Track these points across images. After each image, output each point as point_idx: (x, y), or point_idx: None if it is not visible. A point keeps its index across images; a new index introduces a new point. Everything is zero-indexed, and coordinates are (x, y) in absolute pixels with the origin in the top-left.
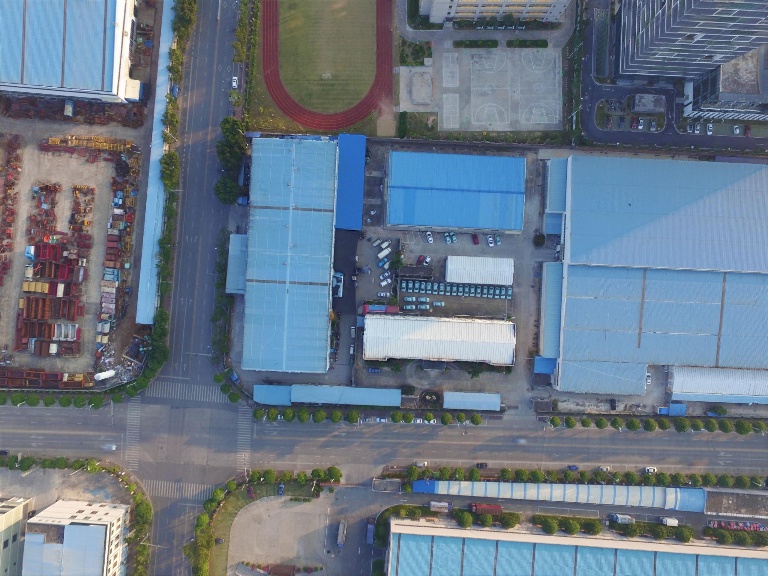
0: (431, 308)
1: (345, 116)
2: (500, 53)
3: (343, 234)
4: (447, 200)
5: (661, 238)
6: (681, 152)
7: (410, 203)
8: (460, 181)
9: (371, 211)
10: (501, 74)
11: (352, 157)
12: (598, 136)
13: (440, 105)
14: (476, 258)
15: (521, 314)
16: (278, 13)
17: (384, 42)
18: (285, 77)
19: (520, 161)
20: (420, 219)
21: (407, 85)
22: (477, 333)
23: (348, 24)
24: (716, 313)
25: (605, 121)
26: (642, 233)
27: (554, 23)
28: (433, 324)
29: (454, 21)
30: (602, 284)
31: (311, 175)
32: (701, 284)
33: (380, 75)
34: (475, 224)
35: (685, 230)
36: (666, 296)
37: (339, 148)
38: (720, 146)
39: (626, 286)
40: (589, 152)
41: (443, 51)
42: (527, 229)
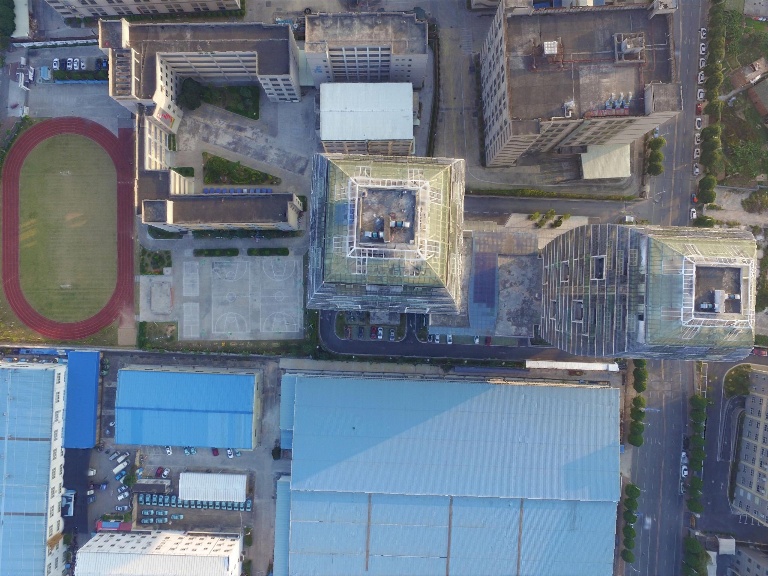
0: (170, 520)
1: (86, 325)
2: (241, 261)
3: (75, 451)
4: (175, 420)
5: (384, 463)
6: (419, 363)
7: (137, 423)
8: (188, 401)
9: (110, 422)
10: (242, 282)
11: (82, 375)
12: (338, 346)
13: (180, 314)
14: (208, 475)
15: (262, 526)
16: (18, 222)
17: (125, 250)
18: (25, 286)
19: (250, 379)
20: (148, 439)
21: (147, 294)
22: (190, 567)
23: (89, 232)
24: (444, 536)
25: (345, 331)
26: (365, 458)
27: (295, 231)
28: (146, 558)
29: (193, 231)
30: (327, 508)
31: (27, 404)
32: (427, 507)
33: (121, 283)
34: (204, 444)
35: (409, 454)
36: (392, 519)
37: (68, 367)
38: (461, 355)
39: (351, 510)
40: (330, 361)
41: (183, 260)
42: (268, 439)
